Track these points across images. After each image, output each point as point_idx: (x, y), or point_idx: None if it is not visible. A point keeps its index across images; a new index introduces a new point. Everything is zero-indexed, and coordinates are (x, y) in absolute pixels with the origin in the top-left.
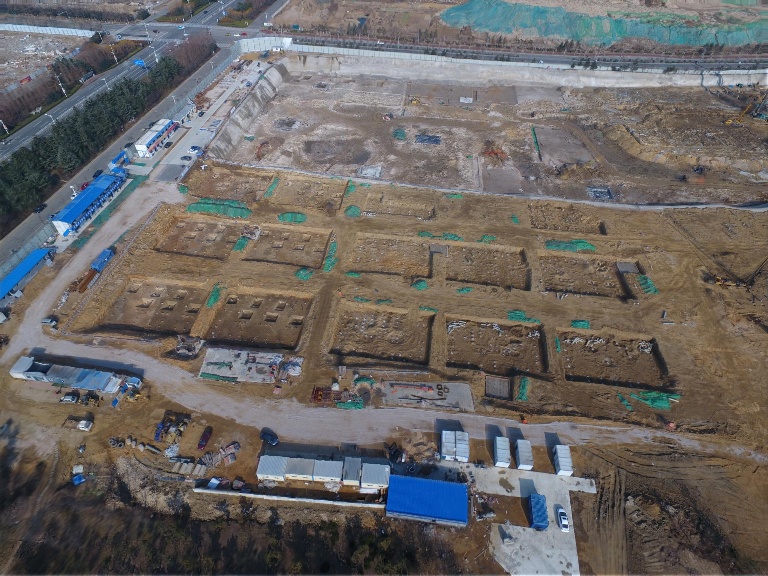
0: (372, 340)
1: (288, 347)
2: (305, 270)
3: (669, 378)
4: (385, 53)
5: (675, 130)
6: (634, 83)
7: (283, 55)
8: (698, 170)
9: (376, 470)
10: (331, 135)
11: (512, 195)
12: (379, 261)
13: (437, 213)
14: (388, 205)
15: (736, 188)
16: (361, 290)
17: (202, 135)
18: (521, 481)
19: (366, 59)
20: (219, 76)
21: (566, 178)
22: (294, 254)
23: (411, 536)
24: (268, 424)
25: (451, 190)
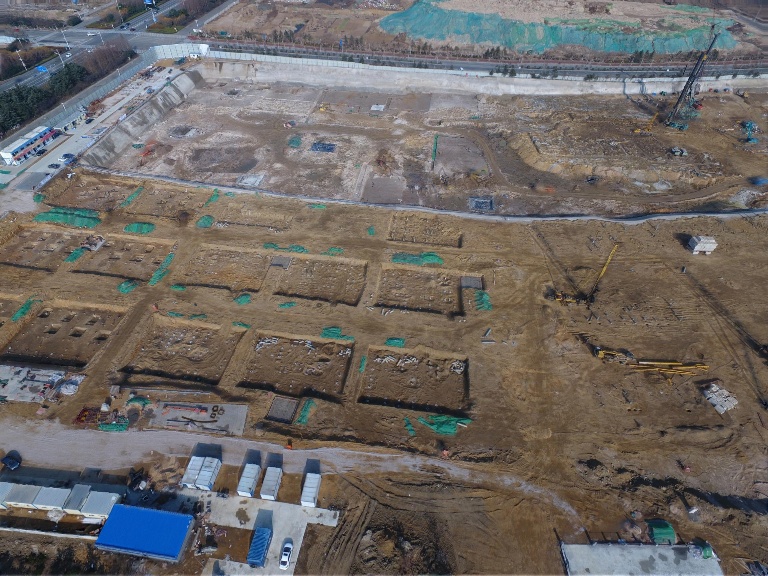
0: (172, 357)
1: (82, 364)
2: (127, 283)
3: (469, 401)
4: (302, 60)
5: (580, 139)
6: (554, 91)
7: (199, 62)
8: (591, 180)
9: (101, 499)
10: (224, 143)
11: (378, 206)
12: (214, 274)
13: (292, 224)
14: (247, 215)
15: (625, 199)
16: (179, 304)
17: (81, 142)
18: (260, 512)
19: (283, 66)
20: (125, 83)
21: (451, 188)
22: (129, 266)
23: (117, 571)
24: (18, 447)
25: (317, 200)
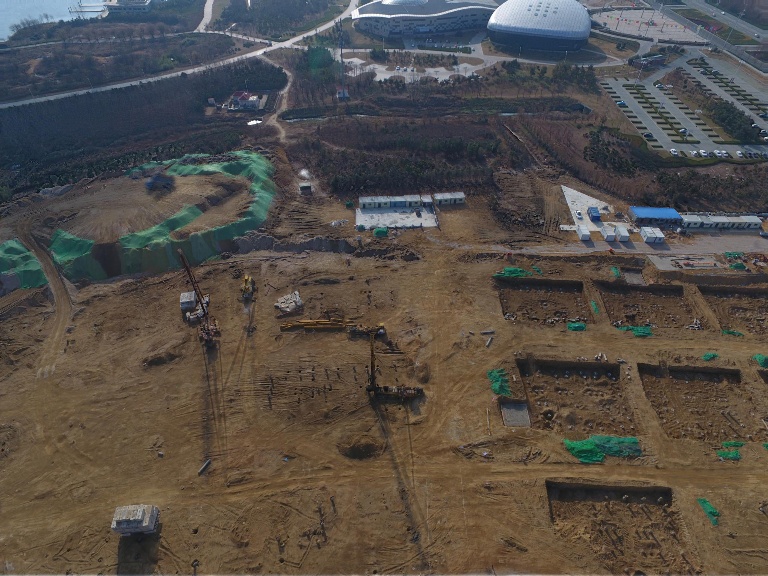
0: None
1: None
2: None
3: None
4: None
5: None
6: None
7: None
8: None
9: (692, 219)
10: None
11: None
12: None
13: None
14: None
15: None
16: None
17: None
18: None
19: None
20: None
21: None
22: None
23: None
24: None
25: None
